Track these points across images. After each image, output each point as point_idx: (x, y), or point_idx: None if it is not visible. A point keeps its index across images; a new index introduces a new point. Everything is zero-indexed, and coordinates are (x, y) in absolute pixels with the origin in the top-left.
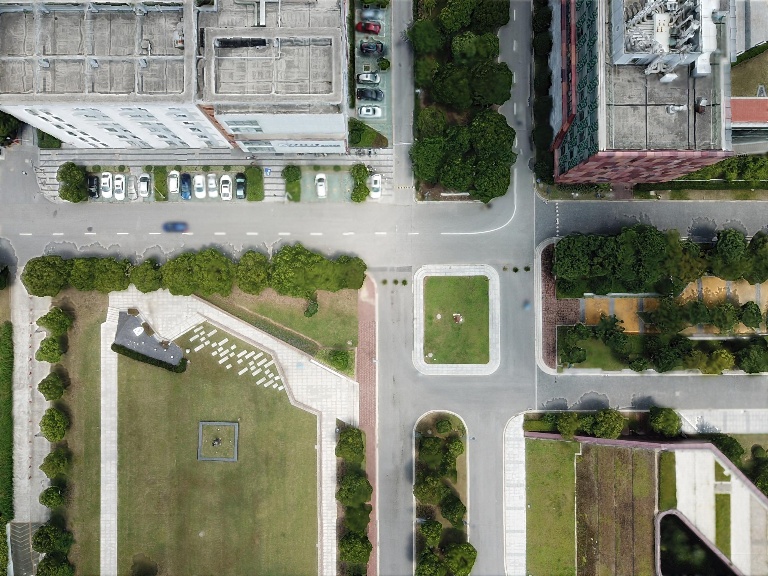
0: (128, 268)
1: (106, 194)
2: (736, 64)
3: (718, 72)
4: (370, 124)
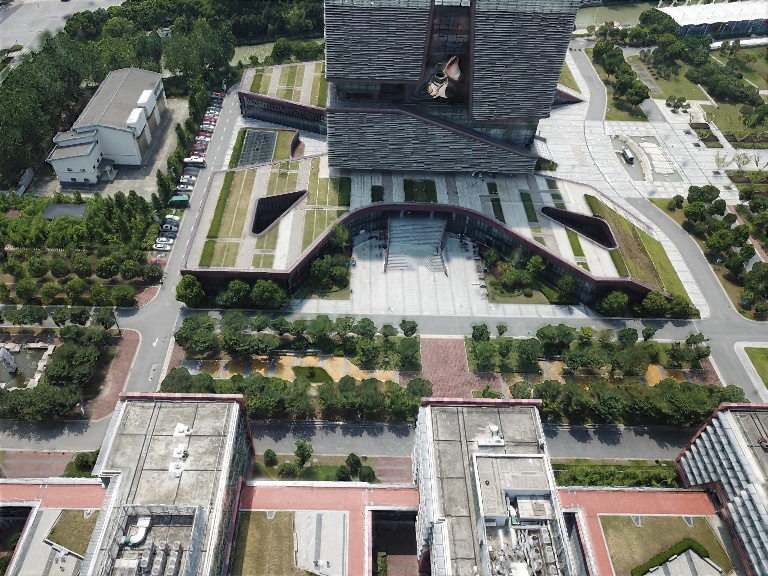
0: None
1: None
2: (674, 546)
3: (762, 473)
4: None
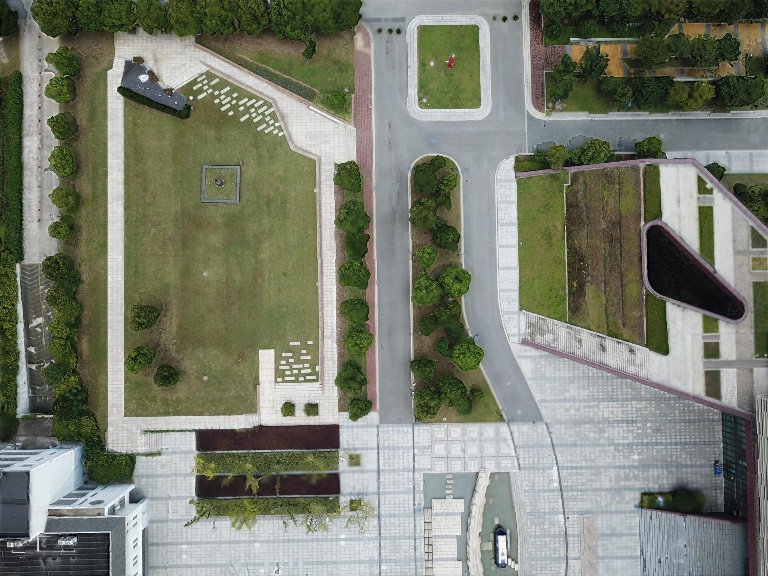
0: (134, 7)
1: None
2: None
3: None
4: None
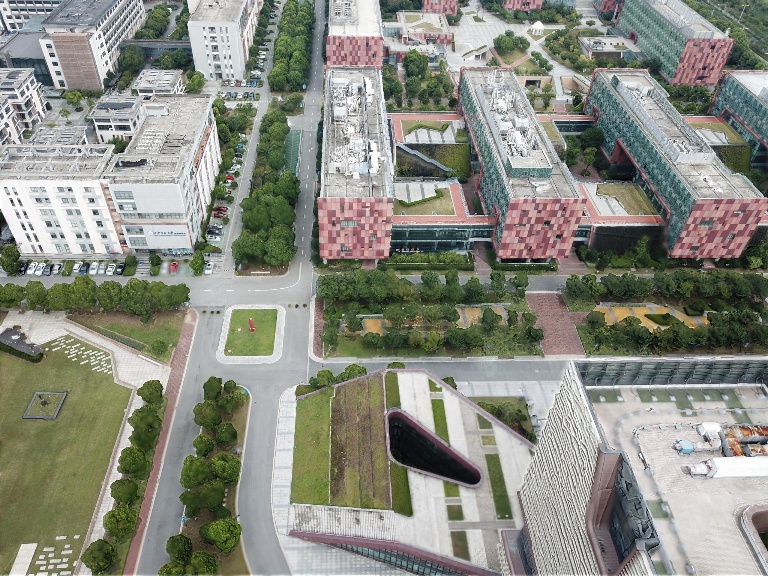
0: None
1: (30, 272)
2: (417, 203)
3: (384, 176)
4: (212, 244)
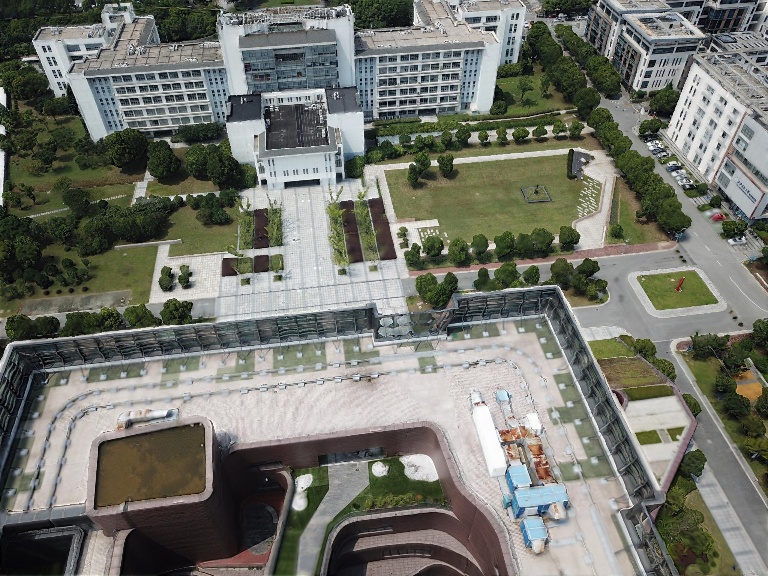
0: None
1: (649, 144)
2: None
3: None
4: None
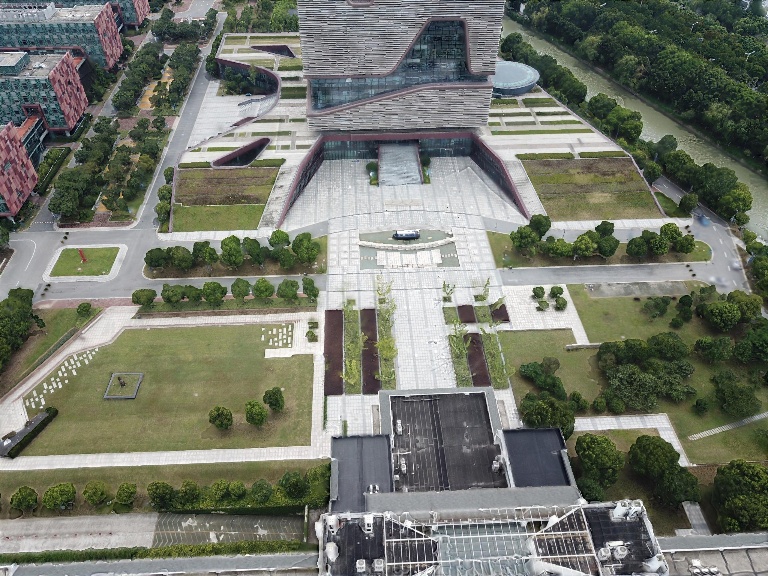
0: None
1: None
2: None
3: None
4: None
